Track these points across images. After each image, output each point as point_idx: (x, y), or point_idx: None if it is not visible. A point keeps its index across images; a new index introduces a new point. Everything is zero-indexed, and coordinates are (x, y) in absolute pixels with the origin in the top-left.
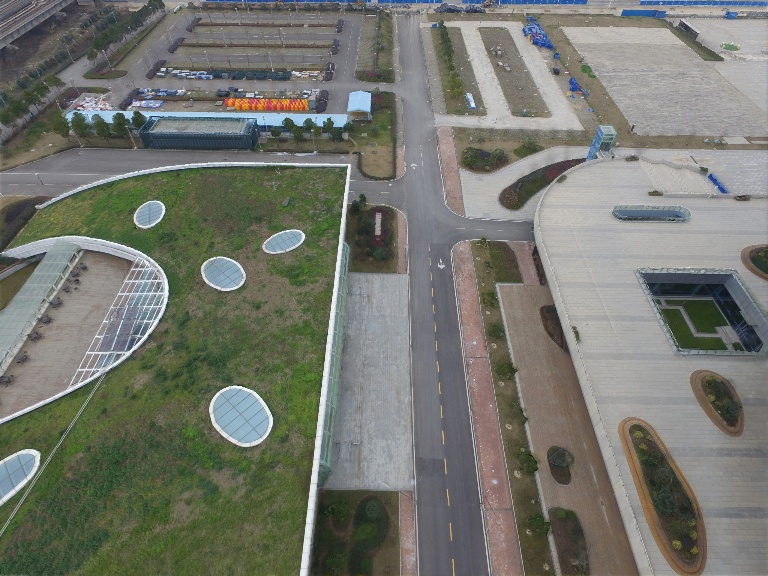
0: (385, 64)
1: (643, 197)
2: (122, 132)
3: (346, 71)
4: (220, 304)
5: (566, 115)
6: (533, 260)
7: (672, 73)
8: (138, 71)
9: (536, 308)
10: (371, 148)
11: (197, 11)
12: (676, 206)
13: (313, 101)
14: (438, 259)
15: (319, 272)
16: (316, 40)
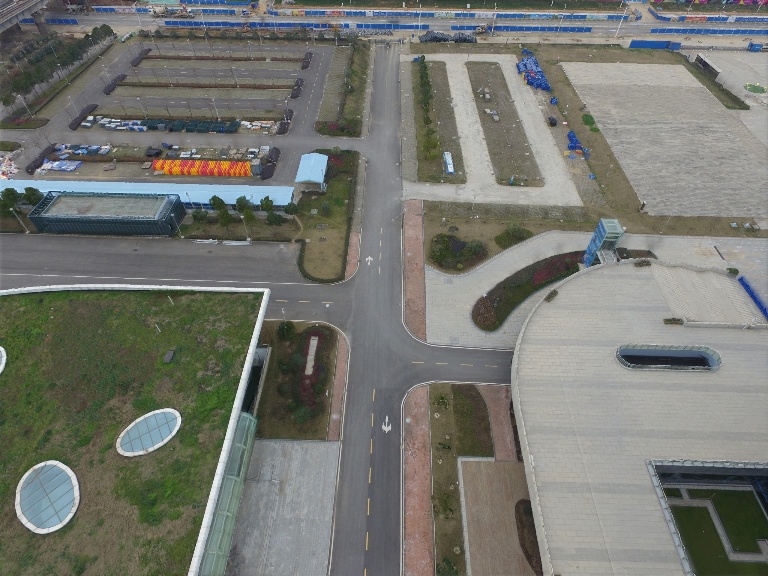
0: (352, 111)
1: (657, 327)
2: (7, 215)
3: (305, 121)
4: (26, 562)
5: (562, 183)
6: (510, 417)
7: (689, 126)
8: (62, 119)
9: (510, 503)
10: (319, 233)
11: (149, 40)
12: (701, 346)
13: (256, 166)
14: (383, 416)
15: (186, 496)
16: (277, 78)
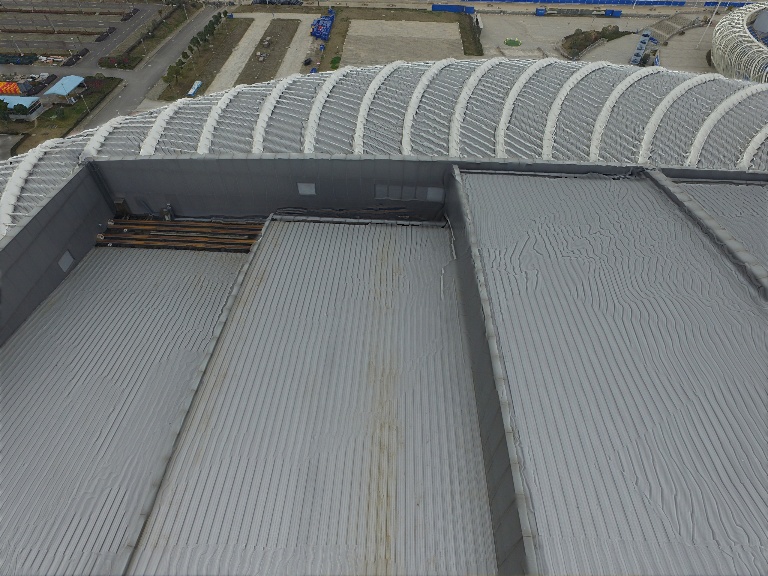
0: (141, 51)
1: None
2: None
3: (95, 57)
4: None
5: None
6: None
7: None
8: None
9: None
10: (47, 130)
11: None
12: None
13: (22, 84)
14: None
15: None
16: (95, 27)
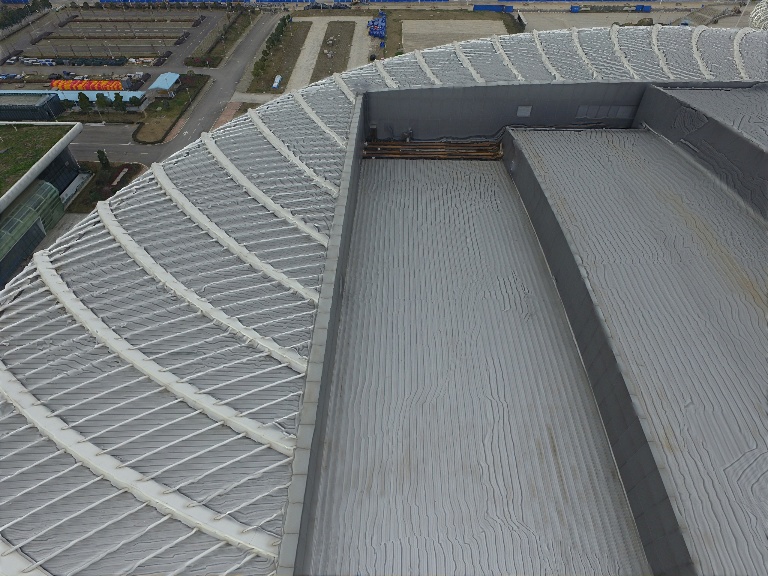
0: (219, 52)
1: None
2: None
3: (179, 58)
4: None
5: None
6: None
7: None
8: None
9: None
10: (157, 119)
11: None
12: None
13: (125, 81)
14: None
15: None
16: (170, 33)
